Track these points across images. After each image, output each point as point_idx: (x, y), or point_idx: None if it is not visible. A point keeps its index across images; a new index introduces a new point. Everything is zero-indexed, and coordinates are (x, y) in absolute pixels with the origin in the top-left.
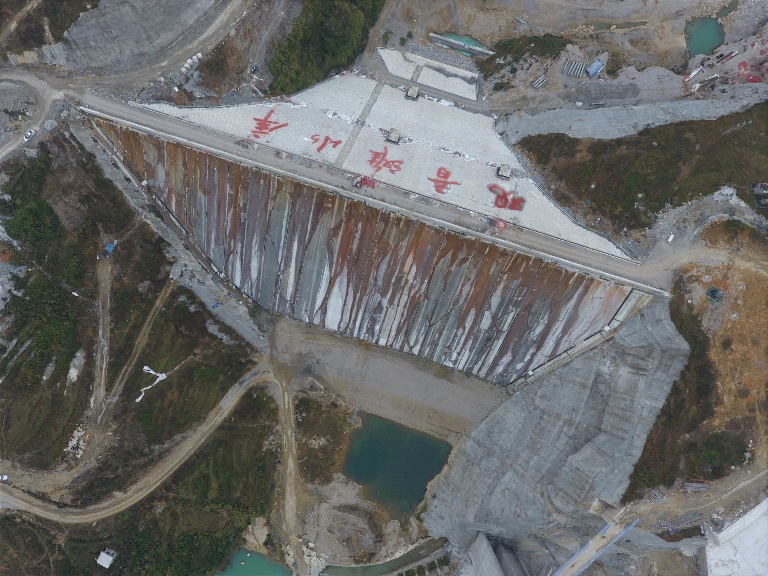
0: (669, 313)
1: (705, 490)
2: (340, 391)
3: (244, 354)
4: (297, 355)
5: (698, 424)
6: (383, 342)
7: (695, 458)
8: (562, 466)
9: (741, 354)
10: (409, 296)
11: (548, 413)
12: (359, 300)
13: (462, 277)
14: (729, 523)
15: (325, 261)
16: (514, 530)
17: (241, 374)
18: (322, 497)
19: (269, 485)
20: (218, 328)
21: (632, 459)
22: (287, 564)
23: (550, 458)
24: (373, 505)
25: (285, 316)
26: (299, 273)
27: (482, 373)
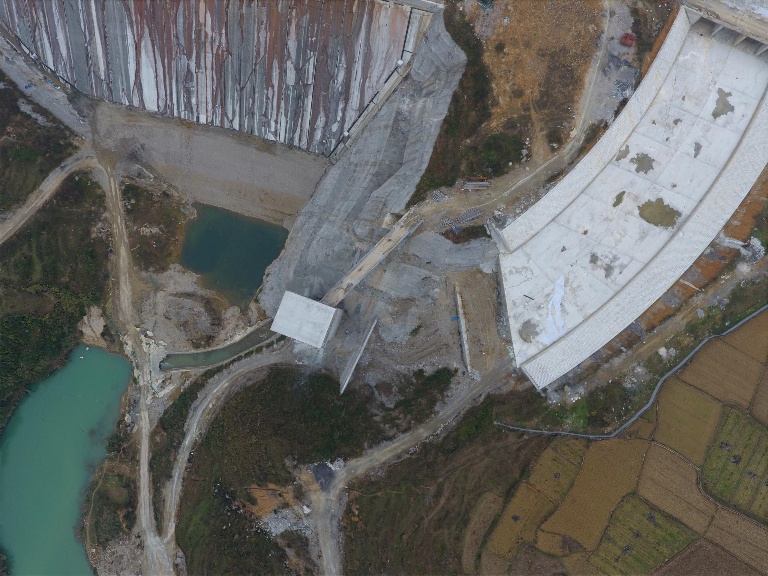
0: (444, 23)
1: (486, 188)
2: (171, 180)
3: (63, 136)
4: (121, 140)
5: (476, 127)
6: (203, 119)
7: (474, 157)
8: (366, 202)
9: (514, 57)
10: (213, 54)
11: (360, 164)
12: (168, 67)
13: (255, 20)
14: (511, 220)
15: (125, 21)
16: (330, 277)
17: (62, 158)
18: (158, 285)
19: (102, 274)
20: (32, 108)
21: (421, 173)
22: (126, 354)
23: (356, 197)
24: (212, 293)
25: (105, 100)
26: (105, 41)
27: (303, 143)
